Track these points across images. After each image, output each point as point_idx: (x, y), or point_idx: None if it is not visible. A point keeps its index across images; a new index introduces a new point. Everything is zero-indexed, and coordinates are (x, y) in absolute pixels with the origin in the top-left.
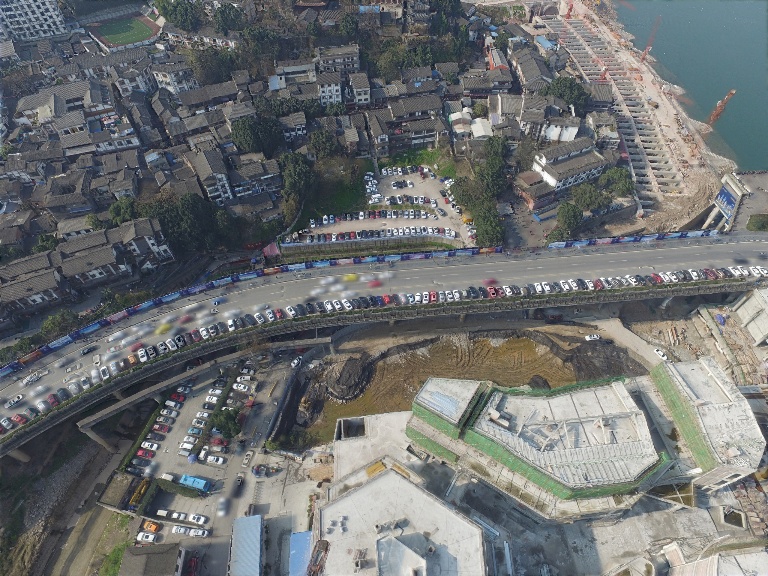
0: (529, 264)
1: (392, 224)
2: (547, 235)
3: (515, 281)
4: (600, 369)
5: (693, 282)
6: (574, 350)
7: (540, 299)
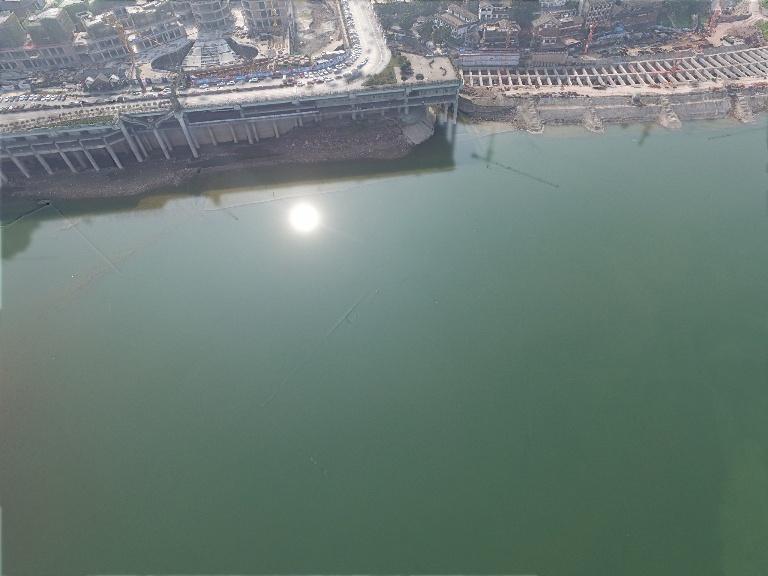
0: (362, 6)
1: (406, 0)
2: (400, 29)
3: (351, 4)
4: (316, 42)
5: (350, 37)
6: (325, 35)
7: (340, 7)
